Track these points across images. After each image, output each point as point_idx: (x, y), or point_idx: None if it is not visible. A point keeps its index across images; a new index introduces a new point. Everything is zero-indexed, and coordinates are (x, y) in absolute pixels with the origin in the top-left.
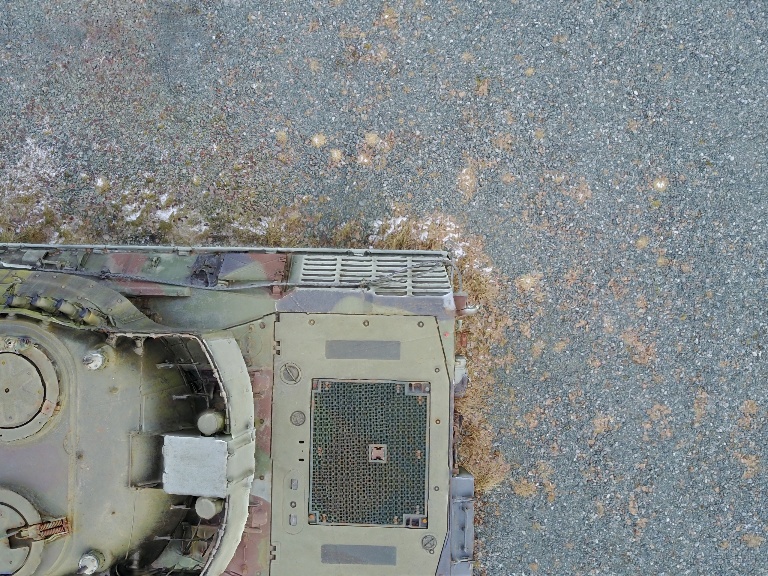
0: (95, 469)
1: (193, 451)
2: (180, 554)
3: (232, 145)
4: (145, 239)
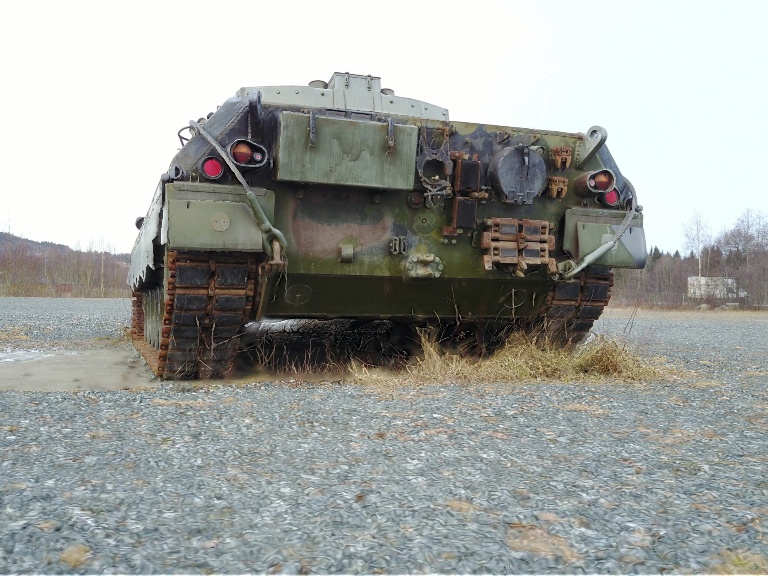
0: None
1: None
2: None
3: None
4: None
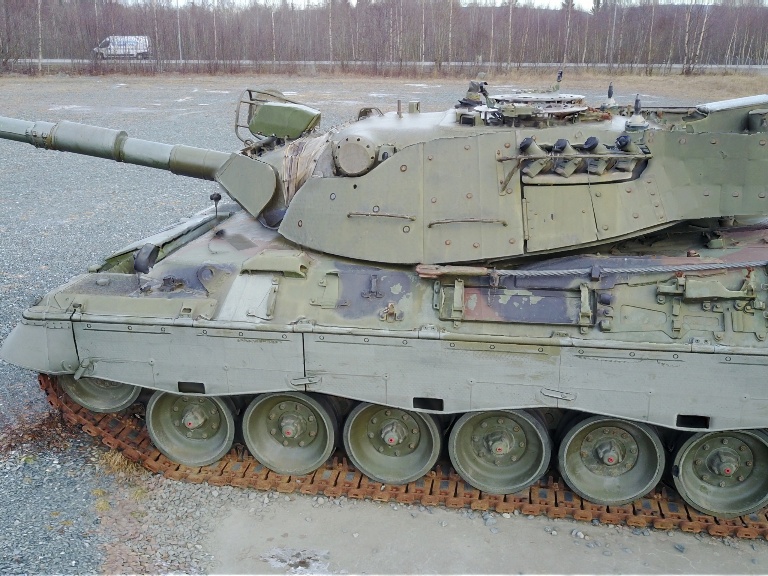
0: (624, 120)
1: None
2: (705, 248)
3: None
4: None
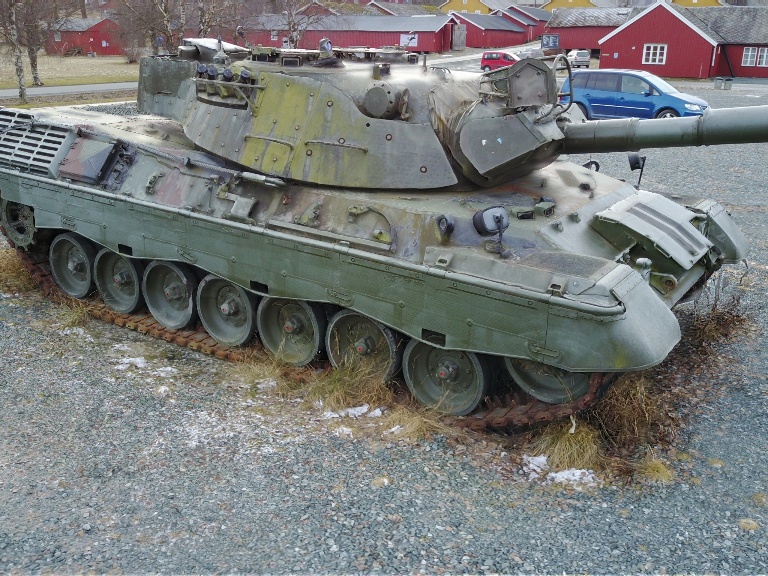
0: None
1: (209, 43)
2: None
3: (6, 366)
4: (180, 360)
